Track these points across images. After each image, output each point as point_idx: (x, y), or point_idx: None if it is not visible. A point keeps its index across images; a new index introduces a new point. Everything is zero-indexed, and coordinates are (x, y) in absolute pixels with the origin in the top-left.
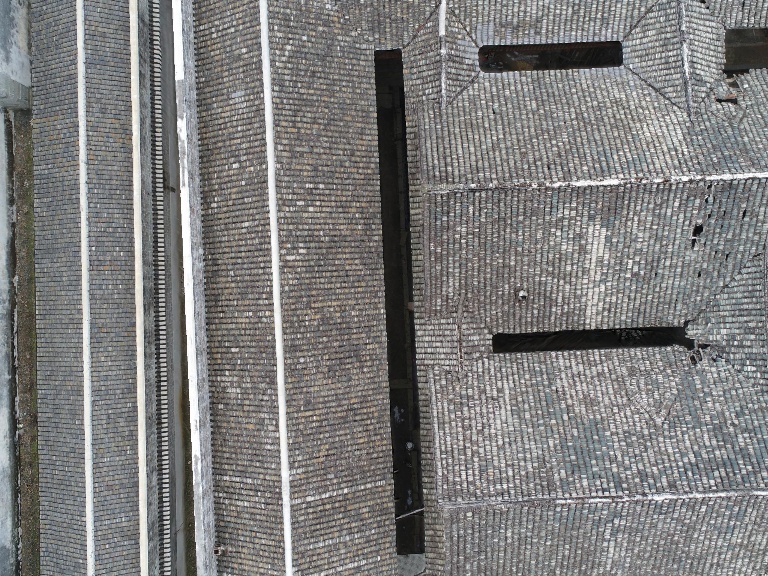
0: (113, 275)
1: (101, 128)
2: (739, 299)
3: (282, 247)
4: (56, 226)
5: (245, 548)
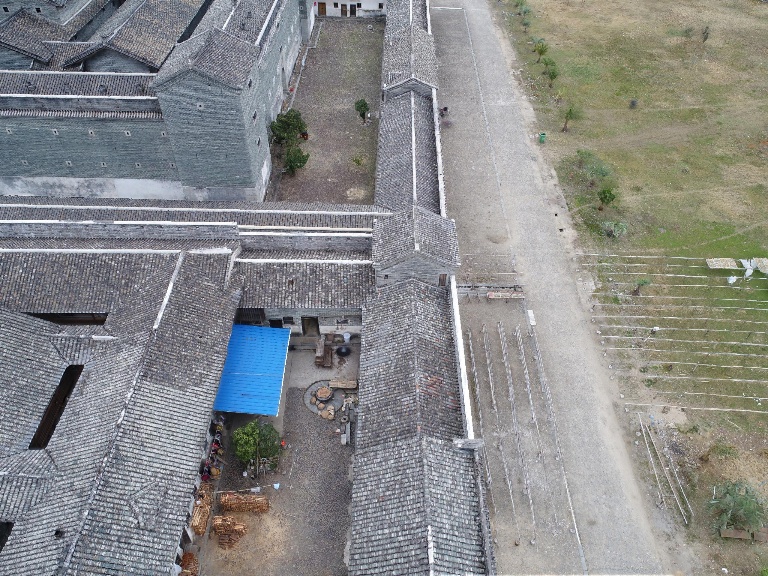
0: (58, 219)
1: (135, 216)
2: None
3: (3, 254)
4: (97, 202)
5: None
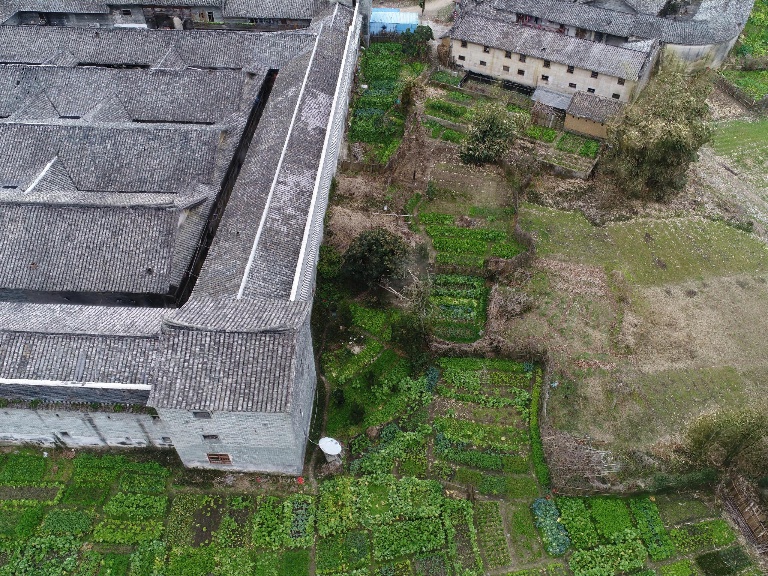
0: None
1: None
2: None
3: None
4: None
5: None
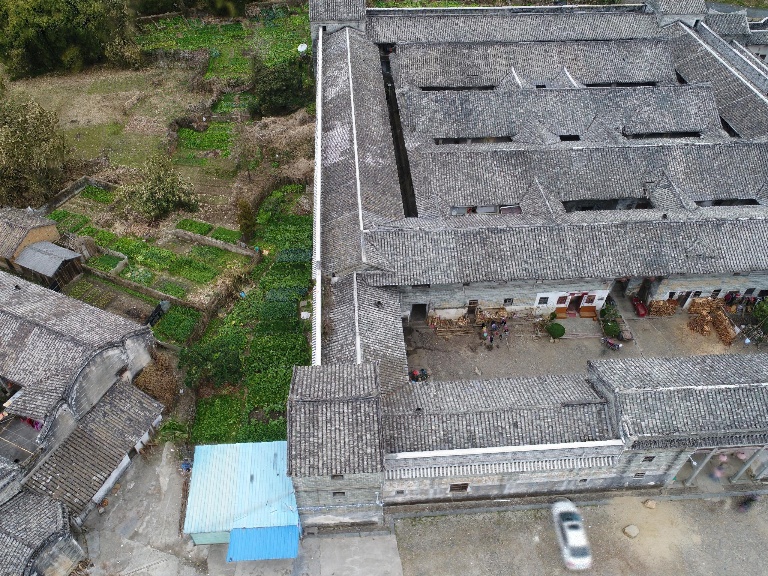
0: None
1: None
2: (618, 137)
3: None
4: None
5: (760, 91)
